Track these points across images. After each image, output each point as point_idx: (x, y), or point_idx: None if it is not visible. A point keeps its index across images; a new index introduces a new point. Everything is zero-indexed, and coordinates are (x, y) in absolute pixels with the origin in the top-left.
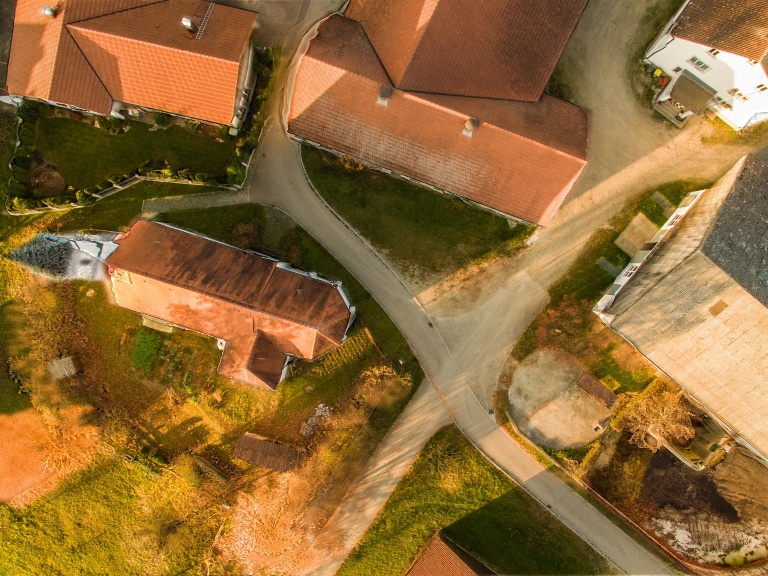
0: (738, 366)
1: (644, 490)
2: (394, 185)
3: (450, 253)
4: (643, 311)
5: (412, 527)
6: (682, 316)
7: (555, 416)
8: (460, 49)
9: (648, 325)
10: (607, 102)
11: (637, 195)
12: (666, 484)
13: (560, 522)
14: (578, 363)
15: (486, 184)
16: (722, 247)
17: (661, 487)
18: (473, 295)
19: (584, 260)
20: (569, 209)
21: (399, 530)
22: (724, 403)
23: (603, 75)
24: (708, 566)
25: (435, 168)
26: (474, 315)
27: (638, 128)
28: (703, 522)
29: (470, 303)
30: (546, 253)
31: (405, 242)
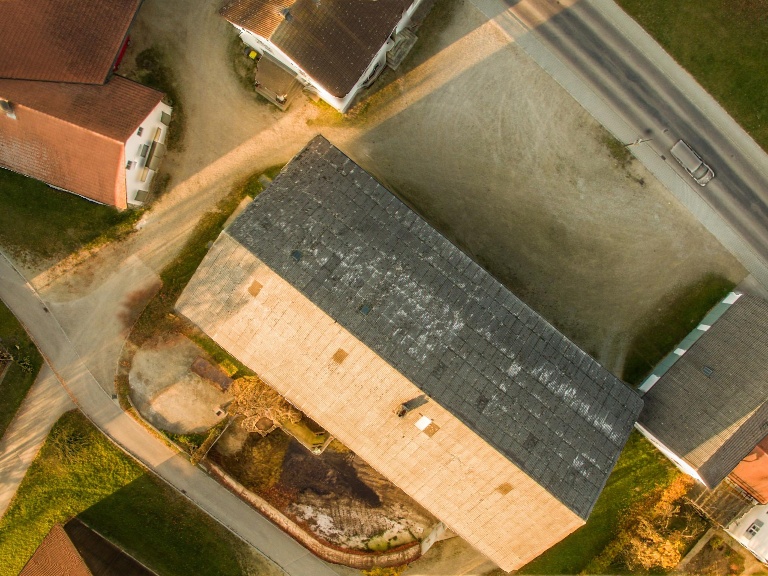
0: (284, 347)
1: (283, 475)
2: (0, 170)
3: (60, 238)
4: (196, 293)
5: (47, 512)
6: (228, 297)
7: (176, 401)
8: (1, 32)
9: (204, 307)
10: (210, 85)
11: (244, 178)
12: (306, 469)
13: (197, 507)
14: (197, 347)
15: (53, 167)
16: (254, 227)
17: (301, 472)
18: (86, 280)
19: (194, 244)
20: (177, 193)
21: (34, 515)
22: (287, 385)
23: (205, 58)
24: (351, 551)
25: (3, 152)
26: (89, 300)
27: (242, 111)
28: (345, 507)
29: (84, 288)
30: (156, 237)
31: (15, 227)
